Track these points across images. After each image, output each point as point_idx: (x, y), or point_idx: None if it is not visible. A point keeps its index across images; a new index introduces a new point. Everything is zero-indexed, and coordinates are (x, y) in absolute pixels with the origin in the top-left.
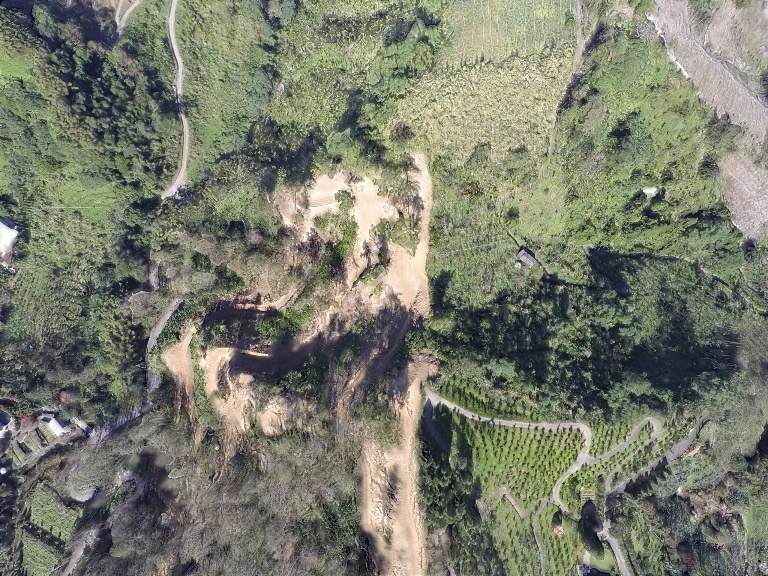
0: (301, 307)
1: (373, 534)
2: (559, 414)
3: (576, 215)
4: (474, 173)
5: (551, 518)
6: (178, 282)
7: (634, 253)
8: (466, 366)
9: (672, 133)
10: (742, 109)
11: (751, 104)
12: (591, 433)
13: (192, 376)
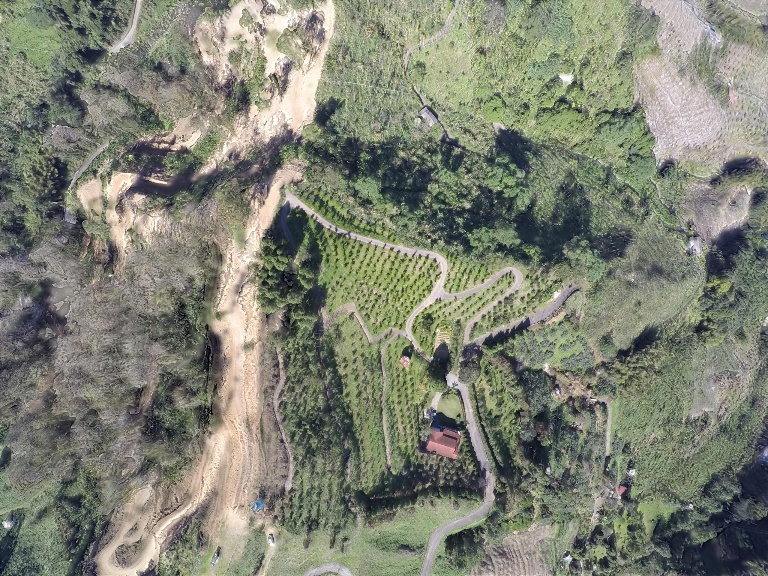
0: (203, 137)
1: (213, 320)
2: (418, 242)
3: (484, 82)
4: (379, 11)
5: (401, 350)
6: (94, 108)
7: (547, 144)
8: (329, 175)
9: (593, 18)
10: (669, 8)
11: (681, 7)
12: (447, 266)
13: (101, 210)
